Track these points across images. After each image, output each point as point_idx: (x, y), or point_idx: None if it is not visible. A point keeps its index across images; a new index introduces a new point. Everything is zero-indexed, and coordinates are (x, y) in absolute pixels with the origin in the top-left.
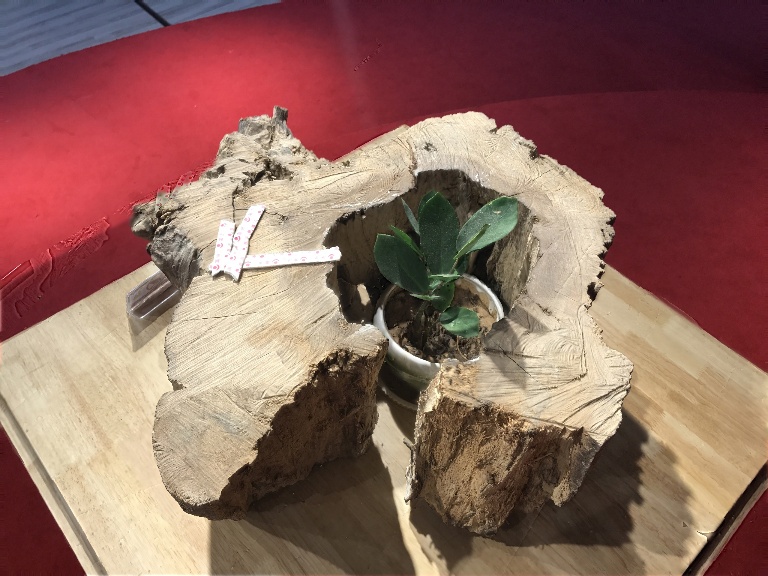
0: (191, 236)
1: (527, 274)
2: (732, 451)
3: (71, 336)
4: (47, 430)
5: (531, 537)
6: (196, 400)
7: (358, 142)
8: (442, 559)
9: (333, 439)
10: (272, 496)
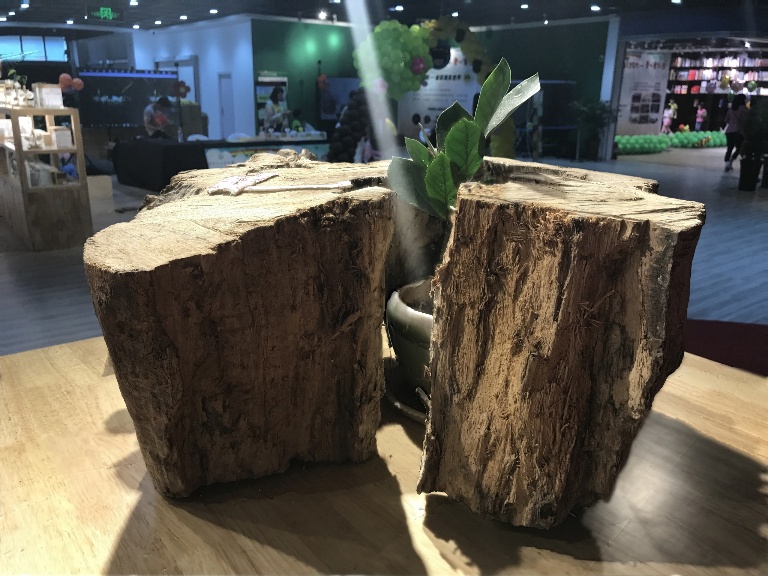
0: (197, 184)
1: None
2: None
3: (38, 364)
4: None
5: (614, 552)
6: (155, 225)
7: None
8: (473, 566)
9: (323, 402)
10: (229, 488)
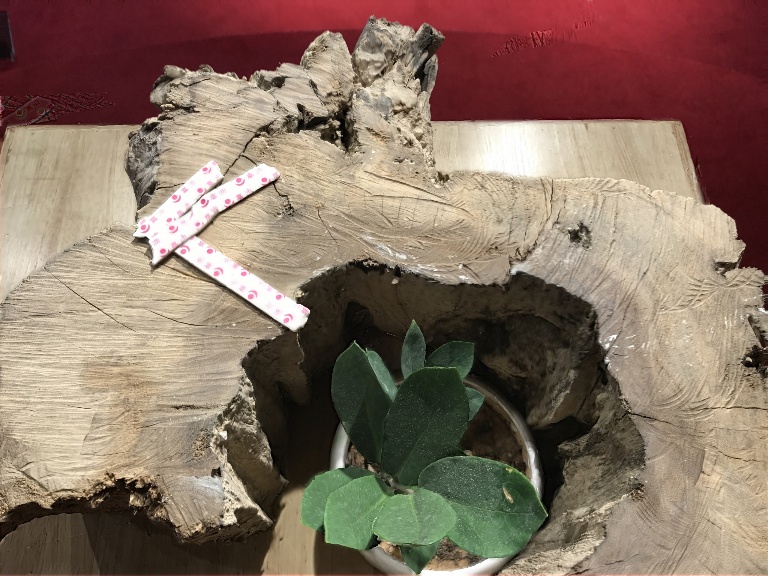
0: (164, 158)
1: (572, 540)
2: None
3: (100, 163)
4: (3, 254)
5: None
6: None
7: (594, 112)
8: None
9: None
10: None
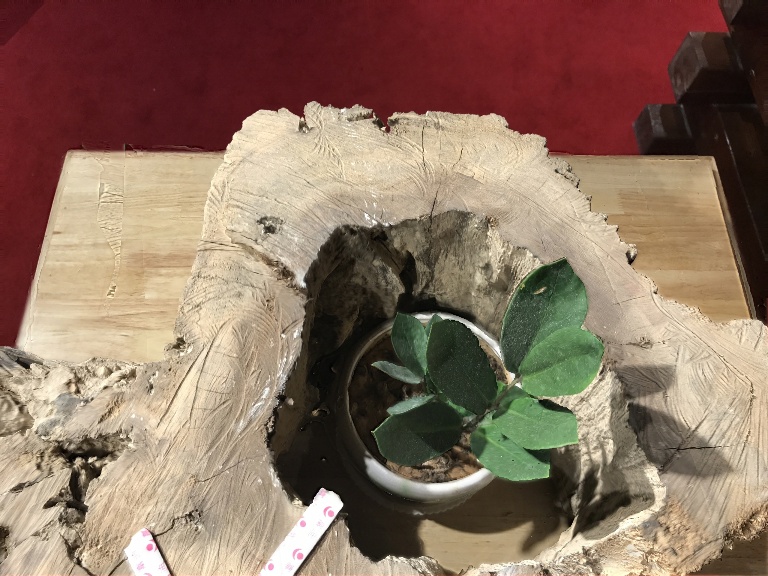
0: None
1: (509, 283)
2: (704, 258)
3: None
4: None
5: None
6: None
7: (38, 223)
8: None
9: None
10: None
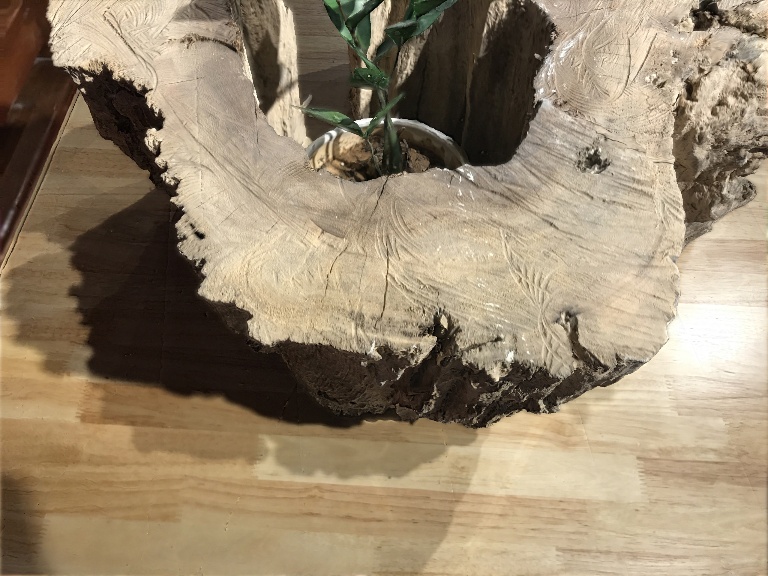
0: None
1: None
2: None
3: None
4: None
5: None
6: None
7: None
8: None
9: None
10: None
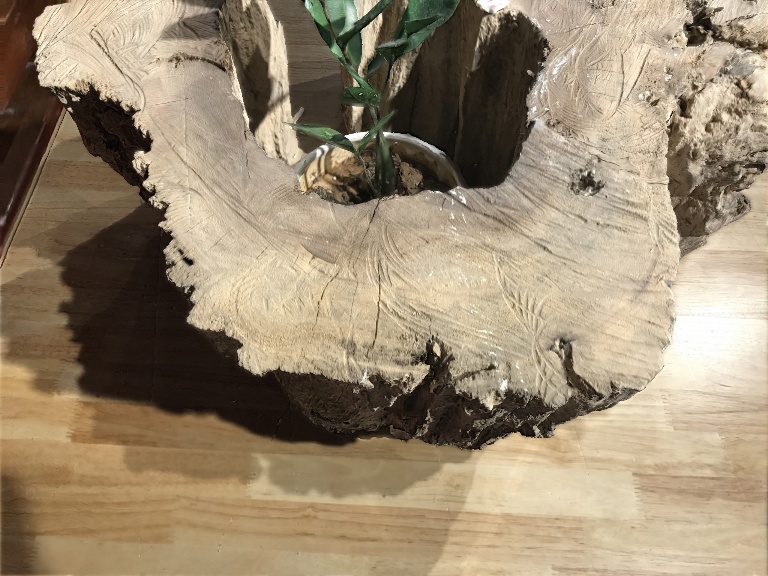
0: None
1: None
2: None
3: None
4: None
5: None
6: None
7: None
8: None
9: None
10: None
